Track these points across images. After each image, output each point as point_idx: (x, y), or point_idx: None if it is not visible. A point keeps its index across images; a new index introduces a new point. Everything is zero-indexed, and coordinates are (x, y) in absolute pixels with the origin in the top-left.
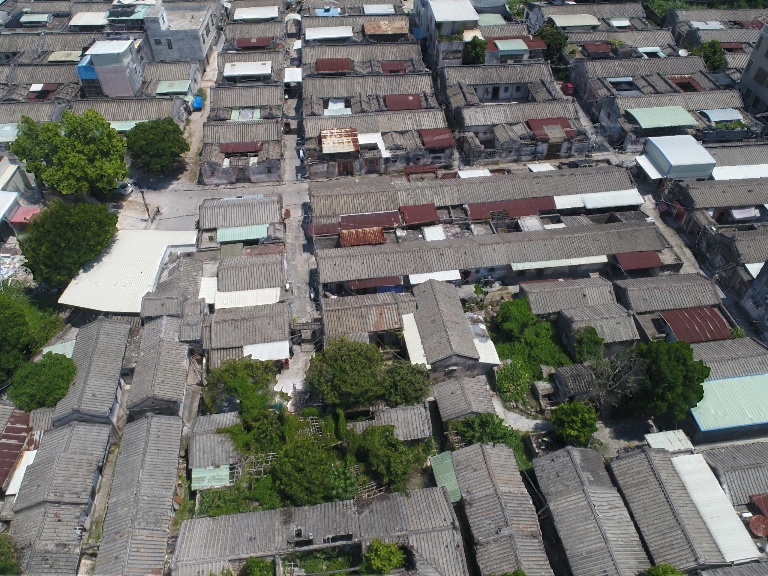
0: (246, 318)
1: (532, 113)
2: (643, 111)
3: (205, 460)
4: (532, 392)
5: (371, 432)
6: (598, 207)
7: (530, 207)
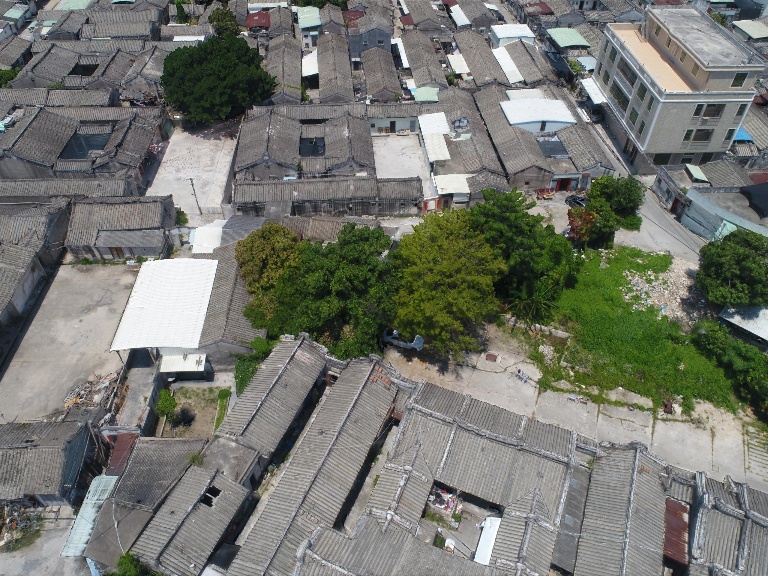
0: None
1: (553, 3)
2: (572, 32)
3: None
4: None
5: None
6: None
7: (449, 1)
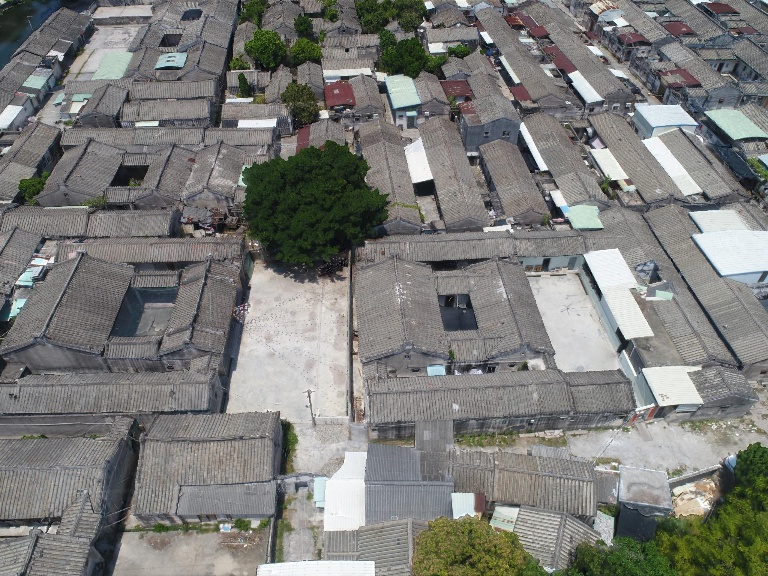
0: None
1: (696, 70)
2: (738, 115)
3: None
4: None
5: None
6: (574, 86)
7: (564, 65)
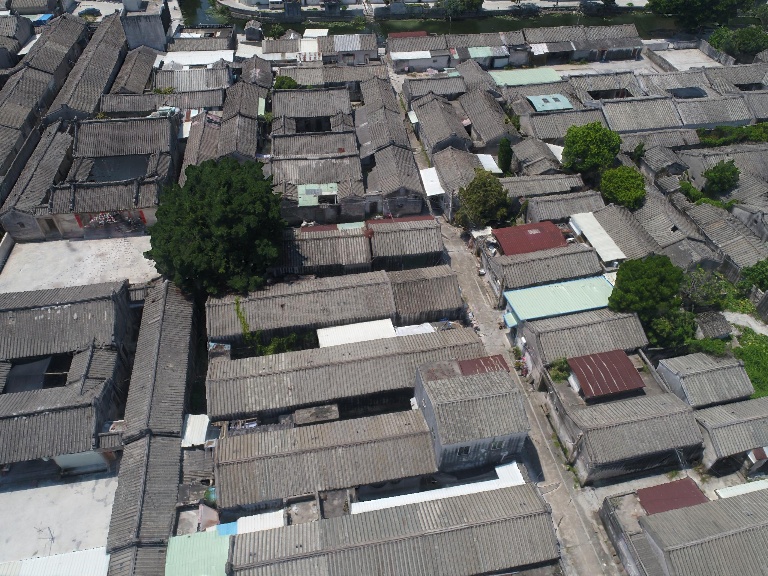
0: None
1: None
2: None
3: None
4: None
5: None
6: None
7: None
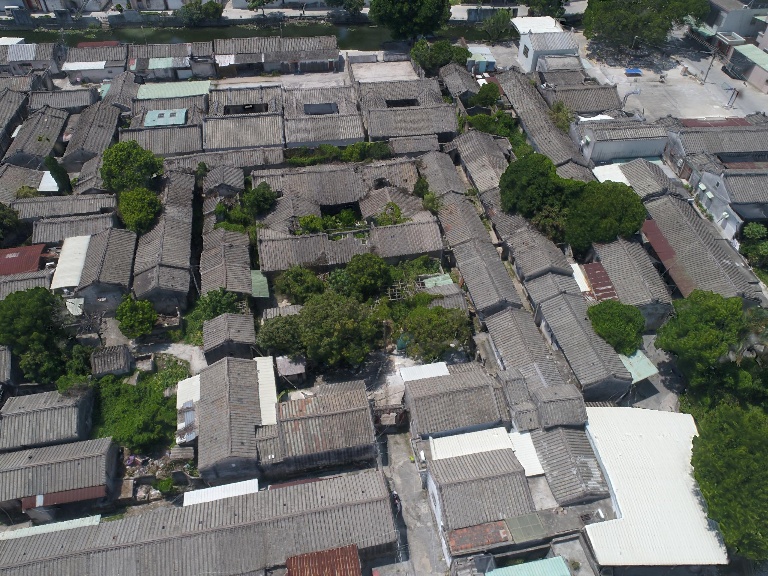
0: (455, 390)
1: None
2: None
3: None
4: (156, 371)
5: (314, 282)
6: None
7: None
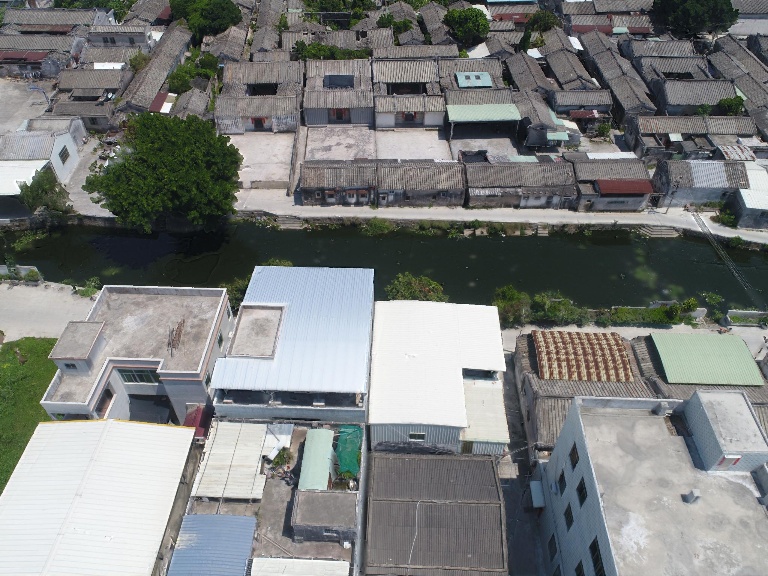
0: None
1: None
2: None
3: (293, 7)
4: None
5: None
6: None
7: None
